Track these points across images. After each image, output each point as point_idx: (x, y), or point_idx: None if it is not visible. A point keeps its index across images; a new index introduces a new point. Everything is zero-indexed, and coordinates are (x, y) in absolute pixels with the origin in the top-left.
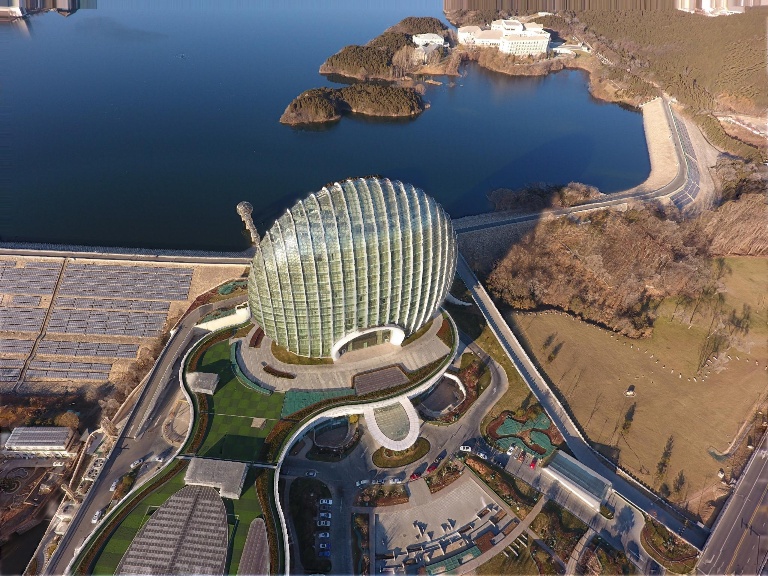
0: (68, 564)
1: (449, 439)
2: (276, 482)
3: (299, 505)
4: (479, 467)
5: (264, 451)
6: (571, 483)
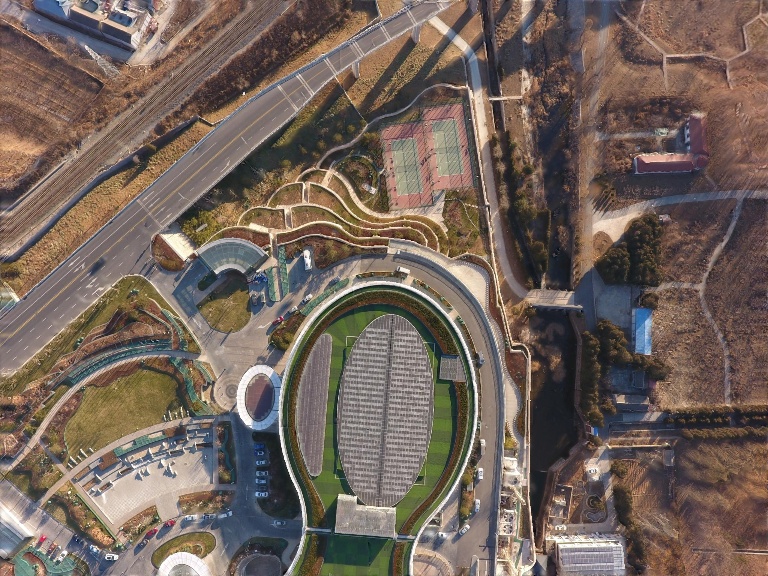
0: (486, 433)
1: (129, 569)
2: (304, 513)
3: (287, 490)
4: (98, 535)
5: (322, 547)
6: (4, 520)
